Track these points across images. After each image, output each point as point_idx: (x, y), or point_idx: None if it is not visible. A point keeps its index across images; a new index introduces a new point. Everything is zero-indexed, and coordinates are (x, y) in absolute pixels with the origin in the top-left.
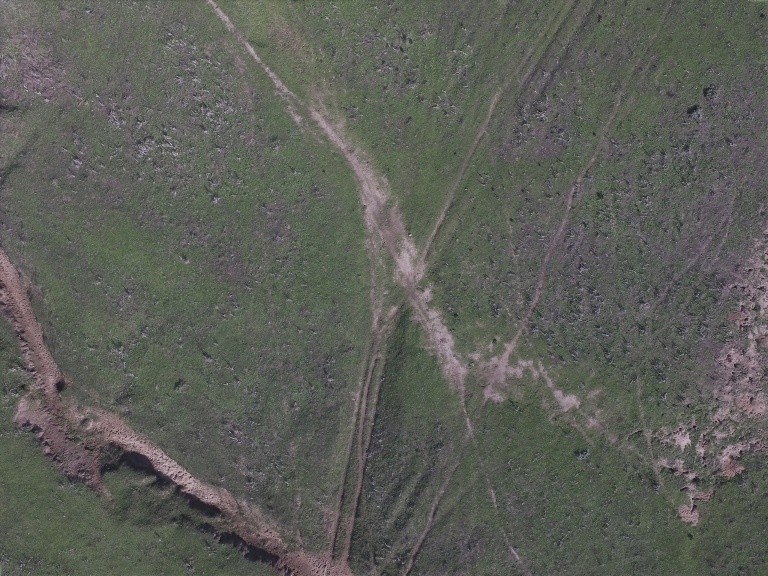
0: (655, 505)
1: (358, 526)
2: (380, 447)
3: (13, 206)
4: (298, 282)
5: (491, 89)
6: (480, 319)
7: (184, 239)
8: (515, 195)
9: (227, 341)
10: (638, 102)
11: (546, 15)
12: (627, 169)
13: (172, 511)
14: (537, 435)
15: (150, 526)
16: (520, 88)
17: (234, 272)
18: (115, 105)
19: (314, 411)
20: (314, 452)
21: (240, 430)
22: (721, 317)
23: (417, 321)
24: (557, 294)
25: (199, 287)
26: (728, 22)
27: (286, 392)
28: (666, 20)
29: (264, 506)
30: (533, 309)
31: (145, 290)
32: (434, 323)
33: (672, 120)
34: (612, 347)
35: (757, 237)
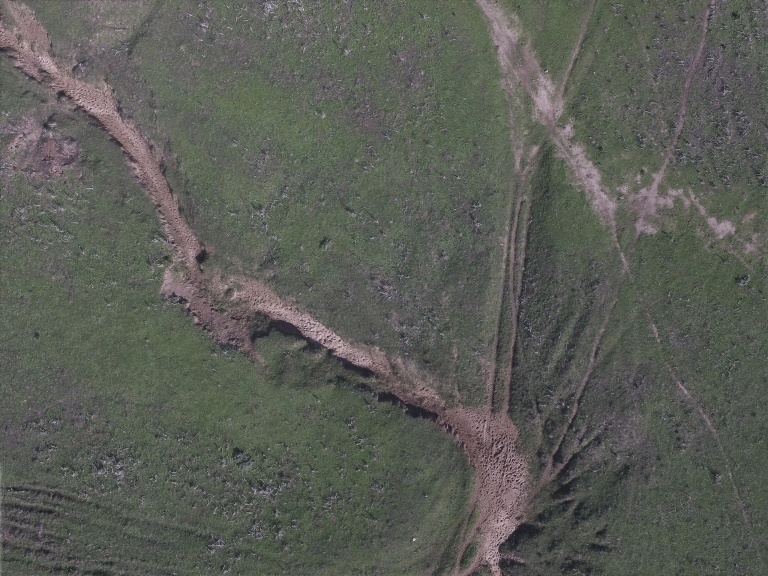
0: None
1: (516, 375)
2: (534, 291)
3: (142, 76)
4: (437, 127)
5: None
6: (626, 150)
7: (317, 94)
8: (649, 22)
9: (370, 194)
10: None
11: None
12: None
13: (327, 373)
14: (695, 264)
15: (307, 388)
16: None
17: (371, 123)
18: None
19: (464, 258)
20: (467, 300)
21: (389, 285)
22: None
23: (561, 158)
24: (702, 119)
25: (337, 142)
26: None
27: (433, 242)
28: None
29: (420, 361)
30: (678, 136)
31: (282, 149)
32: (578, 159)
33: None
34: (763, 168)
35: None
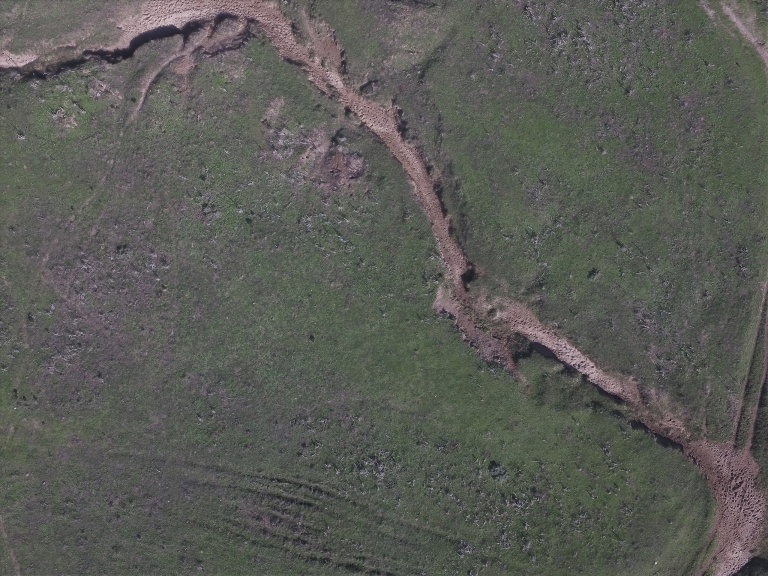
0: None
1: (763, 415)
2: None
3: (432, 99)
4: (713, 172)
5: None
6: None
7: (599, 131)
8: None
9: (641, 230)
10: None
11: None
12: None
13: (584, 397)
14: None
15: (567, 411)
16: None
17: (649, 163)
18: (530, 1)
19: (726, 300)
20: (726, 340)
21: (651, 319)
22: None
23: None
24: None
25: (614, 177)
26: None
27: (698, 281)
28: None
29: (673, 394)
30: None
31: (560, 181)
32: None
33: None
34: None
35: None
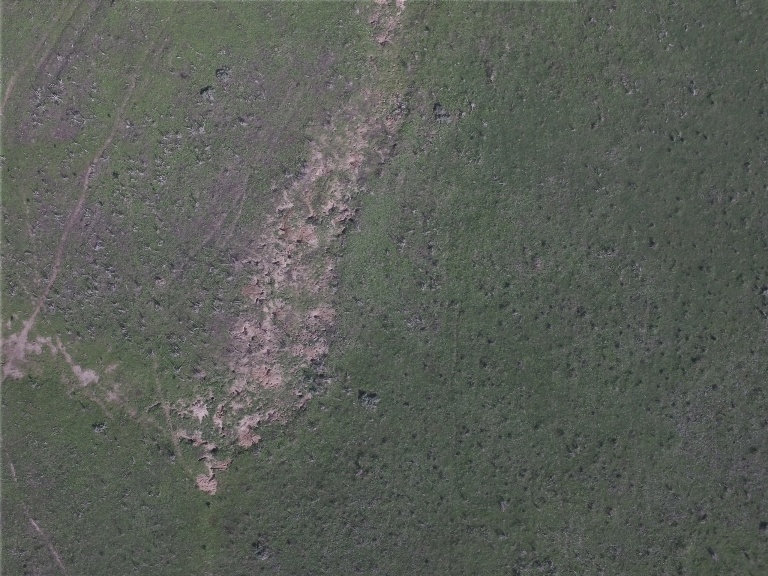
0: (174, 475)
1: None
2: None
3: None
4: None
5: (6, 73)
6: None
7: None
8: (31, 176)
9: None
10: (152, 84)
11: (60, 0)
12: (143, 149)
13: None
14: (54, 409)
15: None
16: (36, 72)
17: None
18: None
19: None
20: None
21: None
22: (235, 291)
23: None
24: (74, 272)
25: None
26: (239, 5)
27: None
28: (179, 4)
29: None
30: (51, 287)
31: None
32: None
33: (186, 101)
34: (128, 322)
35: (269, 213)
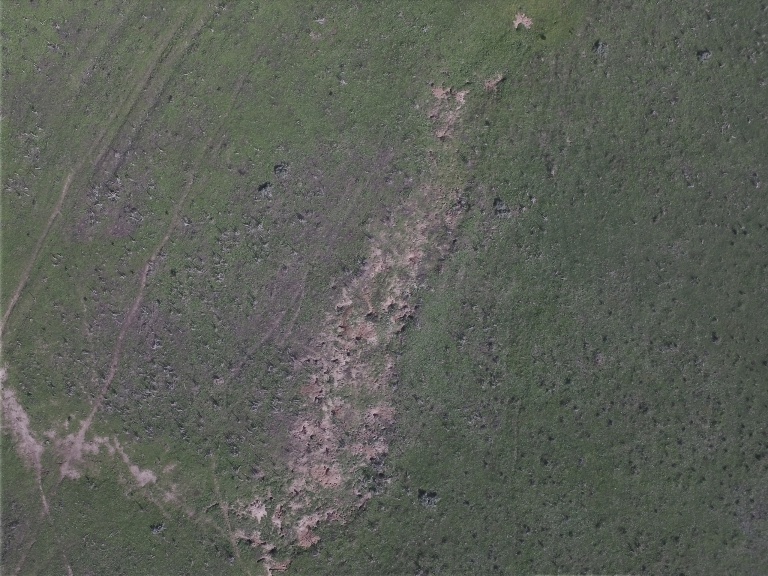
0: None
1: None
2: None
3: None
4: None
5: (63, 170)
6: (53, 398)
7: None
8: (89, 274)
9: None
10: (210, 180)
11: (117, 97)
12: (201, 246)
13: None
14: (112, 511)
15: None
16: (93, 169)
17: None
18: None
19: None
20: None
21: None
22: (294, 390)
23: None
24: (132, 371)
25: None
26: (298, 100)
27: None
28: (237, 99)
29: None
30: (108, 386)
31: None
32: (10, 402)
33: (244, 197)
34: (186, 422)
35: (328, 311)
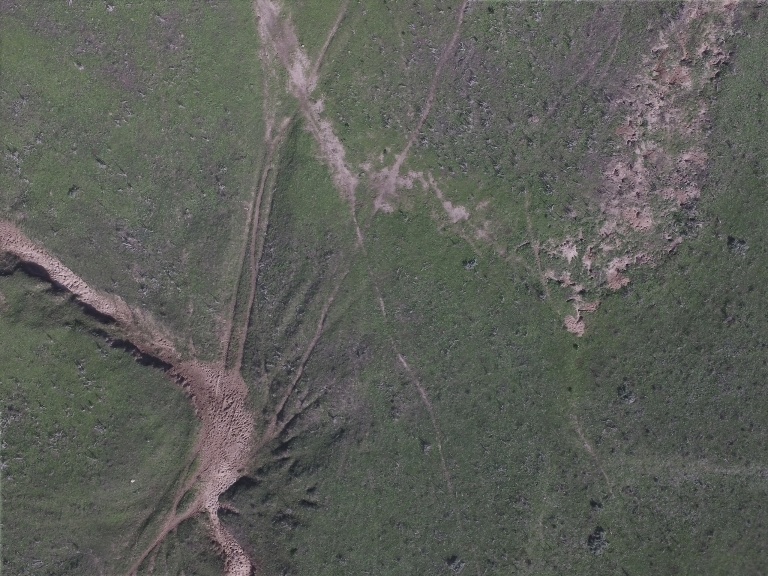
0: (542, 315)
1: (250, 335)
2: (272, 256)
3: None
4: (191, 89)
5: None
6: (371, 129)
7: (79, 46)
8: (407, 9)
9: (120, 147)
10: None
11: None
12: None
13: (65, 316)
14: (426, 244)
15: (42, 328)
16: None
17: (128, 79)
18: None
19: (206, 218)
20: (206, 259)
21: (133, 237)
22: (609, 131)
23: (309, 131)
24: (447, 107)
25: (93, 94)
26: None
27: (179, 199)
28: None
29: (157, 313)
30: (424, 121)
31: (40, 96)
32: (326, 133)
33: None
34: (501, 159)
35: (645, 53)
